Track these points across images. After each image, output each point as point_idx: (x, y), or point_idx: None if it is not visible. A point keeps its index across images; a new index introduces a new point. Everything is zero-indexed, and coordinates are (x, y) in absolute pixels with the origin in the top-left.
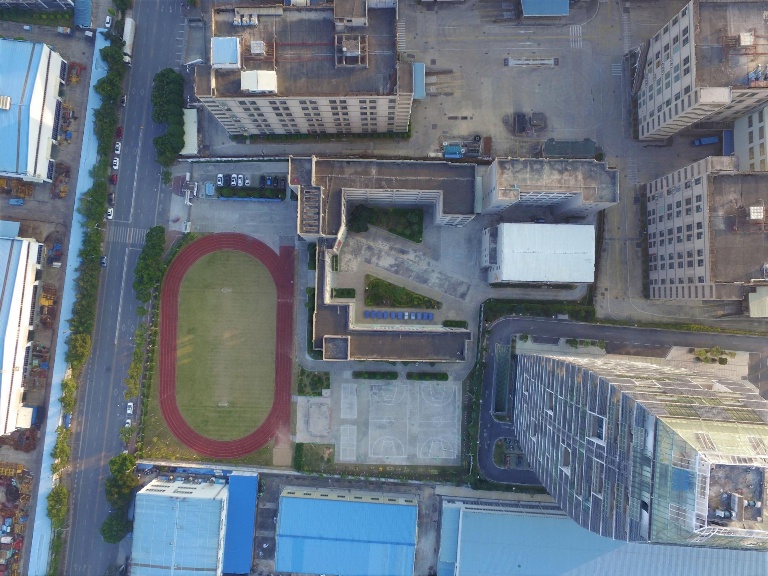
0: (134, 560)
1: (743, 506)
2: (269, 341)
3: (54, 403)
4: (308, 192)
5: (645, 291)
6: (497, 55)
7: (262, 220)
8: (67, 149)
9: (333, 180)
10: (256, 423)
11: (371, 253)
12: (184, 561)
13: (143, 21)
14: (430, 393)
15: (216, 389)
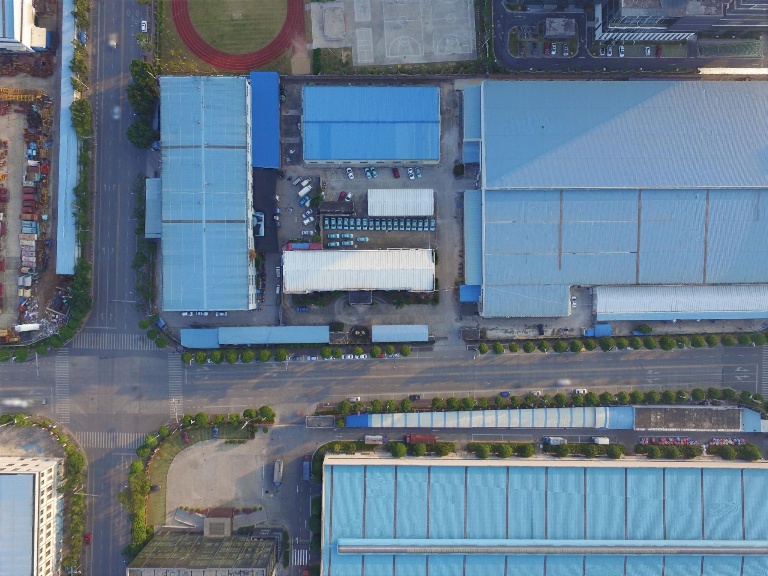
0: (164, 143)
1: None
2: None
3: (67, 18)
4: None
5: None
6: None
7: None
8: None
9: None
10: (272, 34)
11: None
12: (214, 139)
13: None
14: None
15: (229, 3)
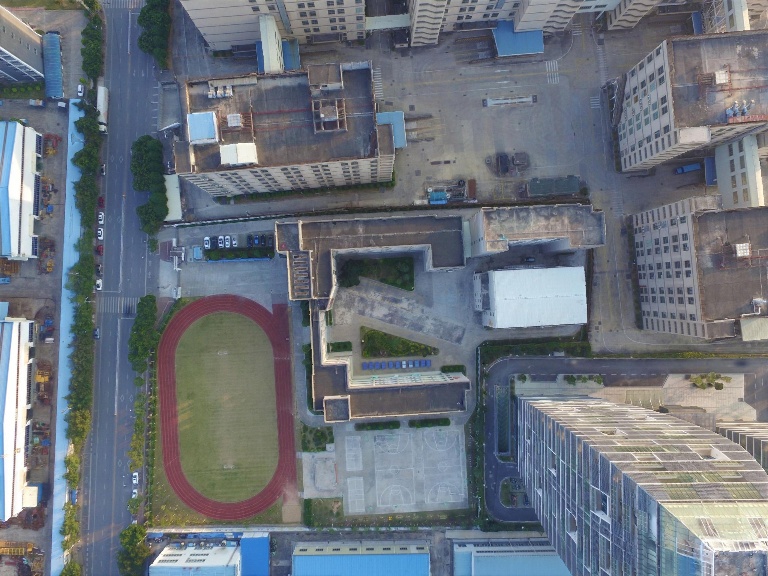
0: None
1: None
2: (269, 400)
3: (59, 480)
4: (297, 257)
5: (638, 322)
6: (475, 96)
7: (253, 280)
8: (50, 223)
9: (321, 242)
10: (263, 482)
11: (364, 305)
12: None
13: (116, 87)
14: (433, 439)
15: (220, 452)
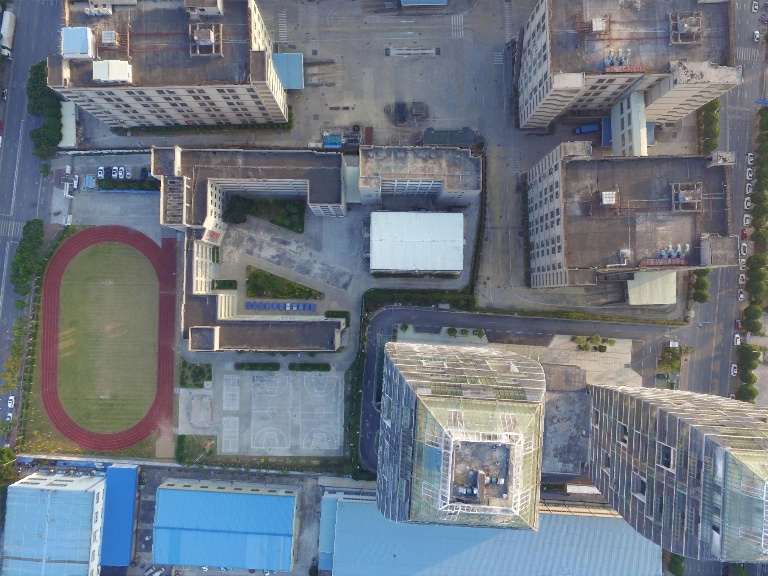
0: (6, 553)
1: (484, 483)
2: (151, 333)
3: None
4: (172, 182)
5: (527, 280)
6: (378, 45)
7: (144, 212)
8: None
9: (199, 170)
10: (139, 415)
11: (253, 244)
12: (56, 554)
13: (24, 14)
14: (312, 384)
15: (98, 382)
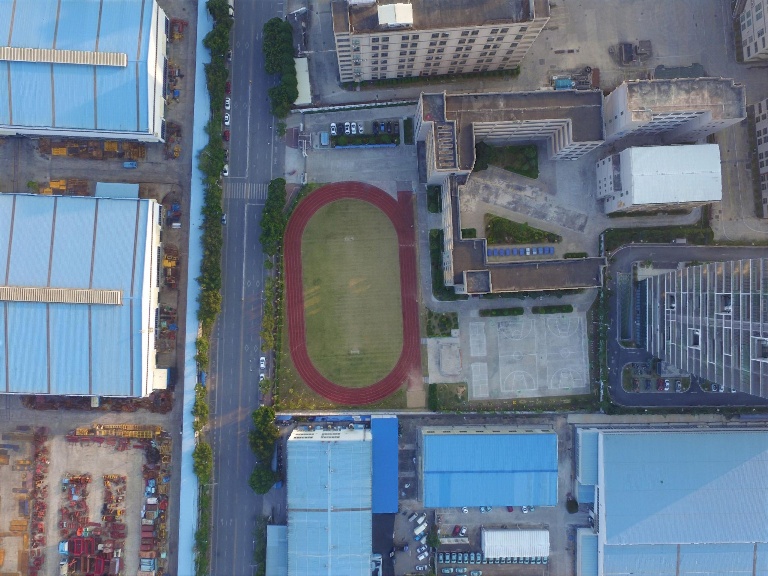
0: (290, 506)
1: None
2: (394, 286)
3: (189, 362)
4: (441, 128)
5: (758, 211)
6: None
7: (378, 167)
8: (176, 108)
9: (462, 115)
10: (388, 368)
11: (489, 192)
12: (340, 503)
13: None
14: (556, 325)
15: (346, 337)
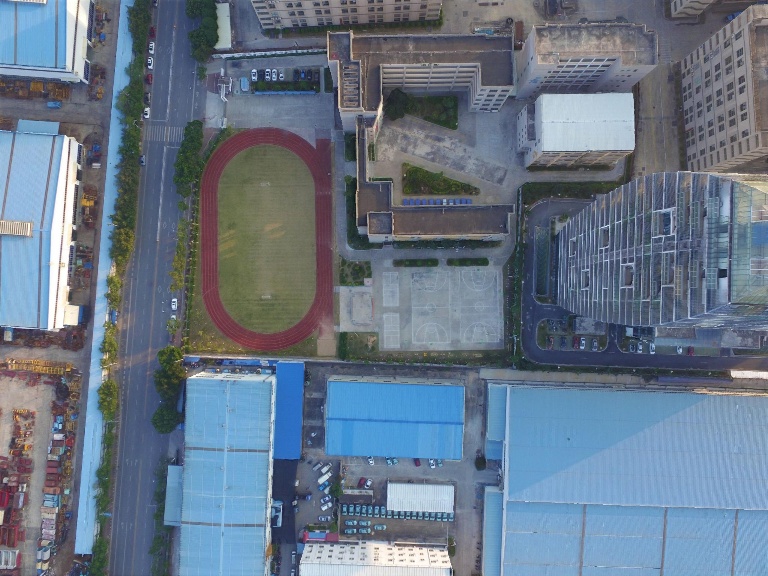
0: (187, 444)
1: None
2: (309, 233)
3: (100, 299)
4: (347, 68)
5: (683, 169)
6: None
7: (297, 114)
8: (101, 51)
9: (371, 57)
10: (299, 315)
11: (407, 142)
12: (237, 443)
13: None
14: (471, 279)
15: (258, 283)
